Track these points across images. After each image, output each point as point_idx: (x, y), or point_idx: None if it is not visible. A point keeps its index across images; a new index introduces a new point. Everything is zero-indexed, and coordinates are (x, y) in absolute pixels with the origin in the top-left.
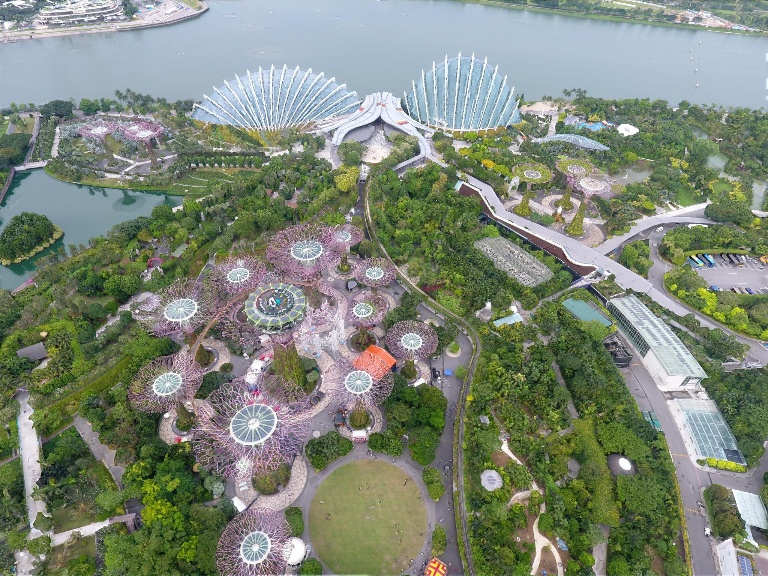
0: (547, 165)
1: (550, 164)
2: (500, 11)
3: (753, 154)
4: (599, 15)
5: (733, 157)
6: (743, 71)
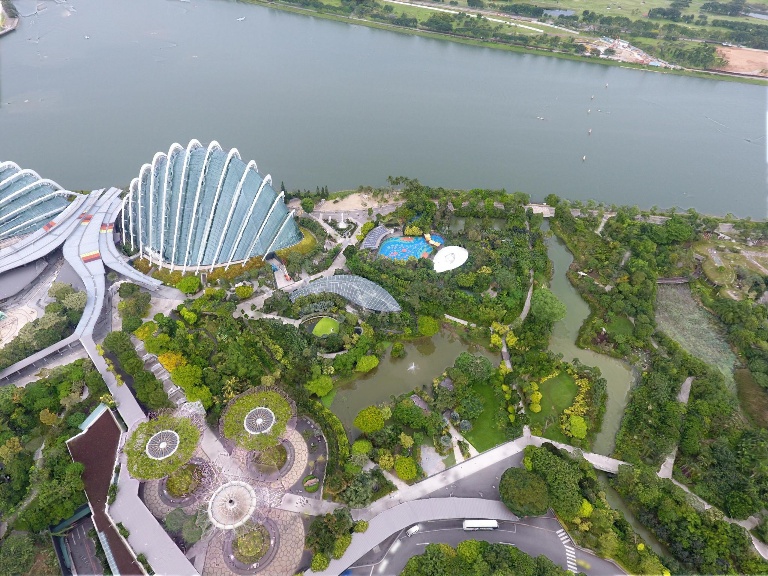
0: (286, 349)
1: (289, 348)
2: (388, 34)
3: (622, 310)
4: (497, 43)
5: (596, 309)
6: (649, 132)
